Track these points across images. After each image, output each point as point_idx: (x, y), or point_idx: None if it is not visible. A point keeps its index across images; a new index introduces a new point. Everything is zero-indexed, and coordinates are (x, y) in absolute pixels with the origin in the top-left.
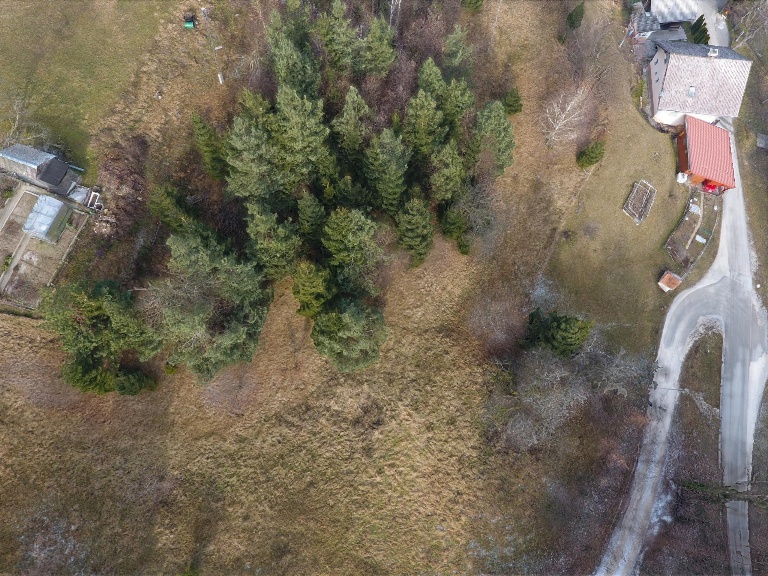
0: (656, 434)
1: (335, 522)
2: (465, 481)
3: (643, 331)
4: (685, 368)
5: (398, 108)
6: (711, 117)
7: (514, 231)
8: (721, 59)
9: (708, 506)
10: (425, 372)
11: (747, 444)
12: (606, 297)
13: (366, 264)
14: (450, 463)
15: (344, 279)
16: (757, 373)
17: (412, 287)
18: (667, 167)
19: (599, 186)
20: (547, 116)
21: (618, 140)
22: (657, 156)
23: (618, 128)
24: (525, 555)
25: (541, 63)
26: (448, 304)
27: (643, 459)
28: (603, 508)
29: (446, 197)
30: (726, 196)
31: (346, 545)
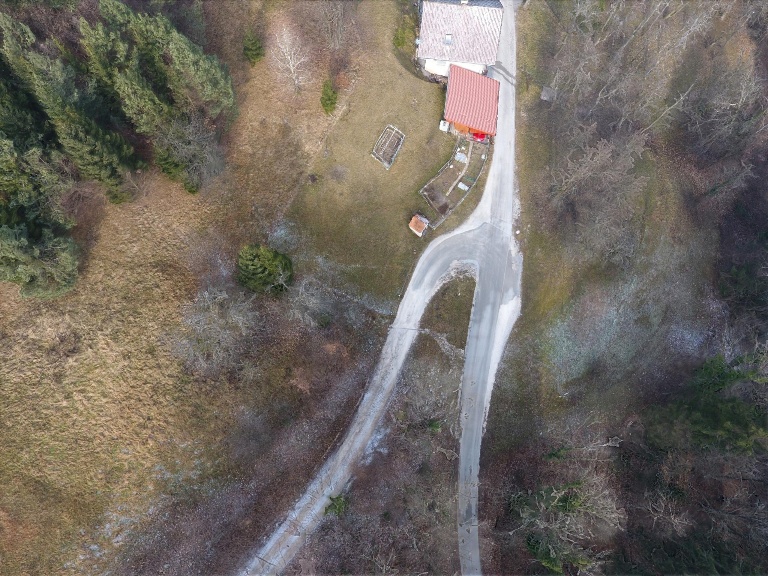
0: (387, 371)
1: (9, 442)
2: (157, 407)
3: (391, 274)
4: (429, 309)
5: (75, 39)
6: (476, 66)
7: (258, 174)
8: (473, 6)
9: (436, 441)
10: (131, 304)
11: (488, 383)
12: (351, 240)
13: (39, 191)
14: (143, 390)
15: (30, 208)
16: (506, 316)
17: (128, 223)
18: (427, 115)
19: (347, 131)
20: (275, 58)
21: (370, 86)
22: (416, 104)
23: (371, 75)
24: (213, 479)
25: (297, 11)
26: (171, 241)
27: (370, 394)
28: (311, 438)
29: (142, 130)
30: (498, 146)
31: (18, 464)
